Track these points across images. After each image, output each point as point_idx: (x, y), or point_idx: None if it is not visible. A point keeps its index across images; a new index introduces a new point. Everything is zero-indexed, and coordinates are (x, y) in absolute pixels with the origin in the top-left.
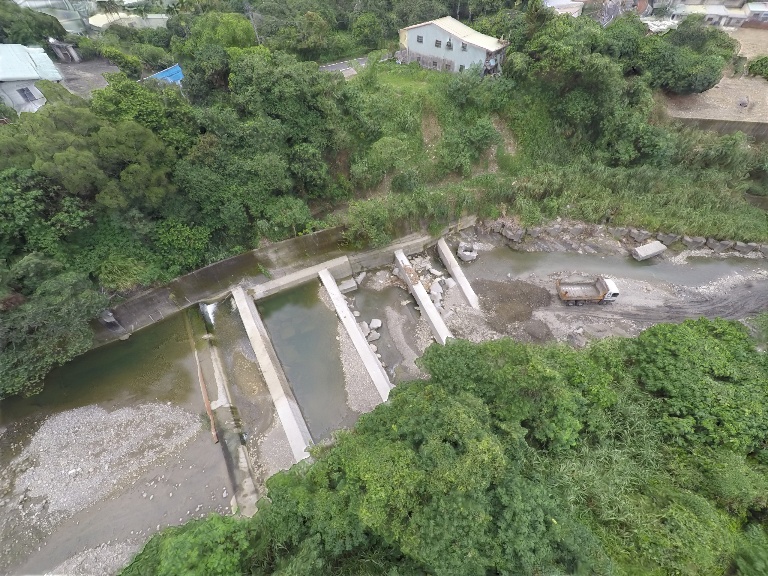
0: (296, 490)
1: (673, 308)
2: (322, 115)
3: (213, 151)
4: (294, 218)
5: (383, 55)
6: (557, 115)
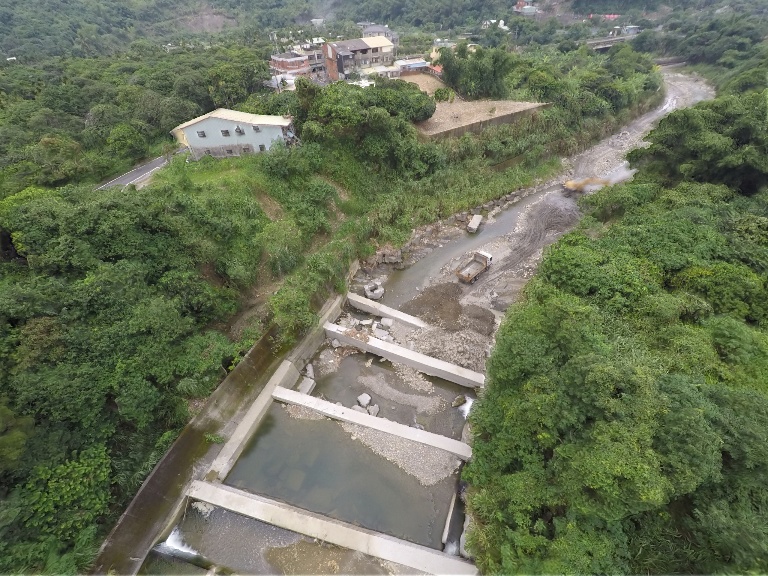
0: (547, 569)
1: (517, 249)
2: (171, 234)
3: (59, 338)
4: (222, 353)
5: (157, 161)
6: (362, 158)
